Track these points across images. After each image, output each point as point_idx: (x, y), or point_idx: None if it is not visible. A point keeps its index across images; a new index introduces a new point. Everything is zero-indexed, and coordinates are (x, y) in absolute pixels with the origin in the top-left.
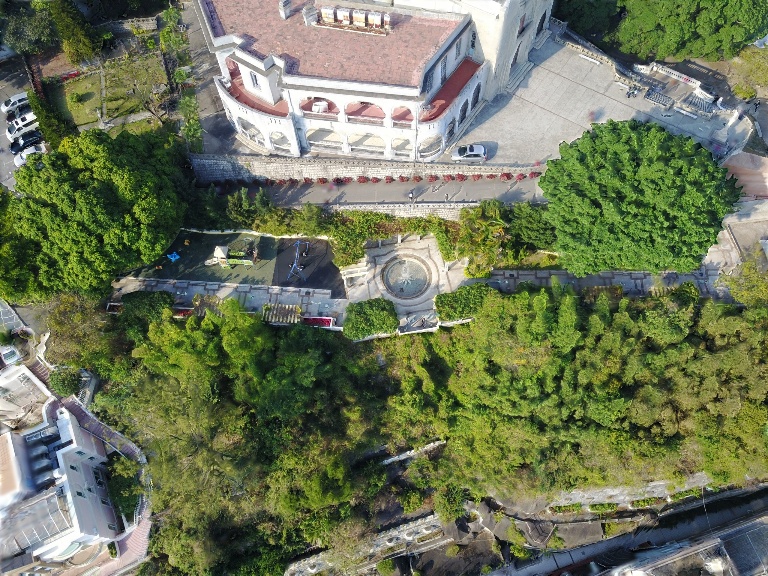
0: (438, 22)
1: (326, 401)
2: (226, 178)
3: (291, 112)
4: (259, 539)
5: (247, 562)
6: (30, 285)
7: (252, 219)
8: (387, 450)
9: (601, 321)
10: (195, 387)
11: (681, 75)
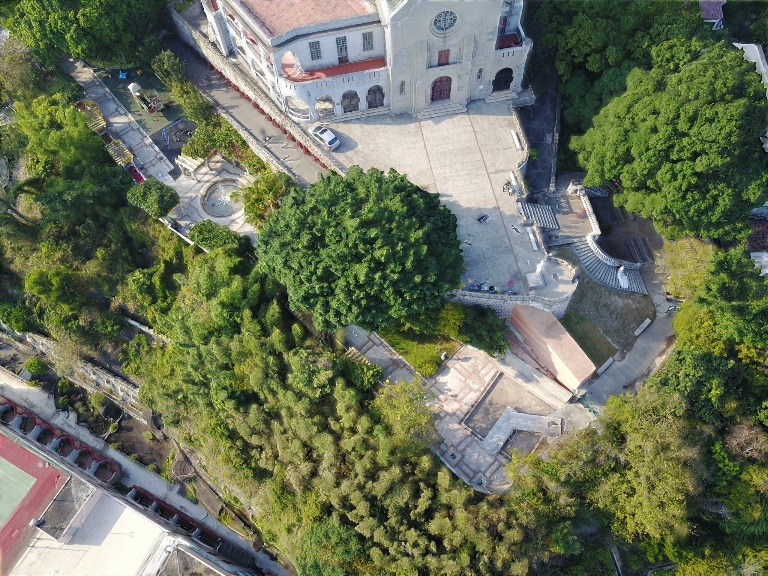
0: (358, 7)
1: (93, 231)
2: (192, 45)
3: (219, 11)
4: (23, 294)
5: (8, 302)
6: (8, 22)
7: (169, 80)
8: (112, 302)
9: (252, 319)
10: (5, 143)
11: (592, 214)
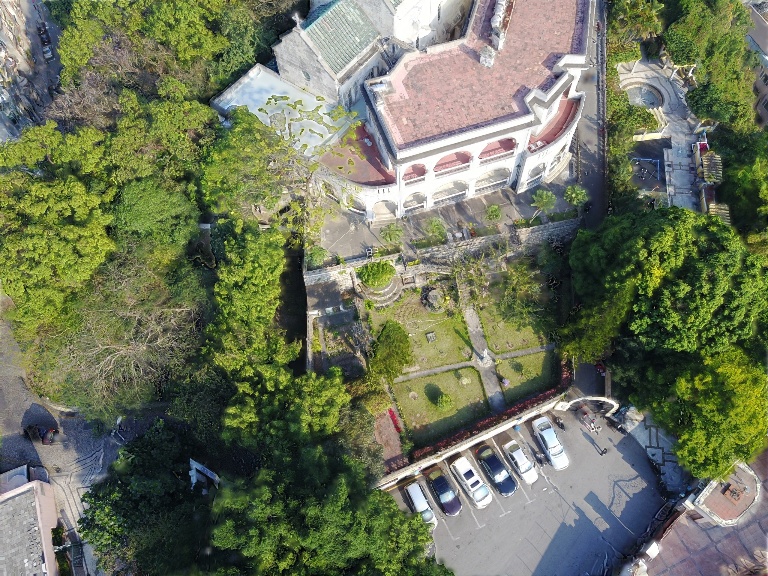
0: None
1: None
2: None
3: None
4: None
5: None
6: None
7: None
8: None
9: None
10: None
11: None
